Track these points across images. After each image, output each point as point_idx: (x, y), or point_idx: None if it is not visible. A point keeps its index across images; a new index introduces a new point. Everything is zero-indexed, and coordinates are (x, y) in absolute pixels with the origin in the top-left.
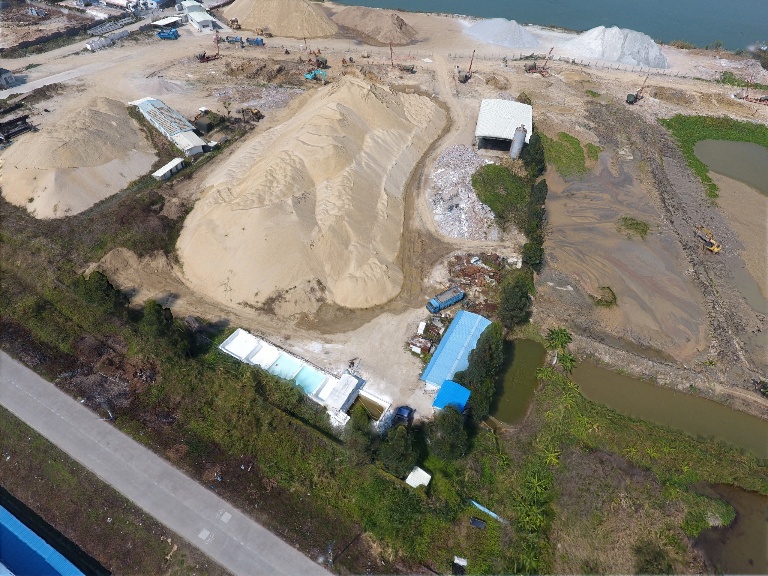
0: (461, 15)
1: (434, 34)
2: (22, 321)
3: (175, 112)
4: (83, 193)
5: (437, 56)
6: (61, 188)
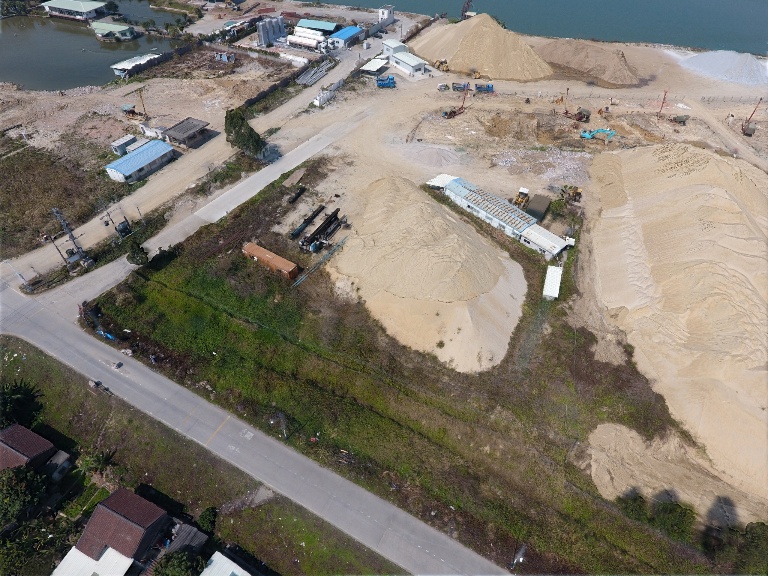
0: (663, 44)
1: (655, 70)
2: (583, 565)
3: None
4: (495, 331)
5: (687, 100)
6: (478, 328)
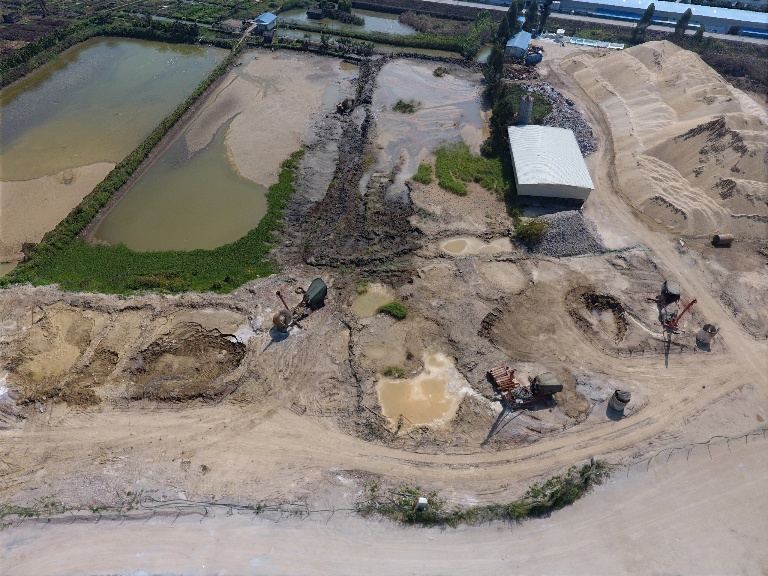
0: None
1: None
2: None
3: None
4: None
5: None
6: None
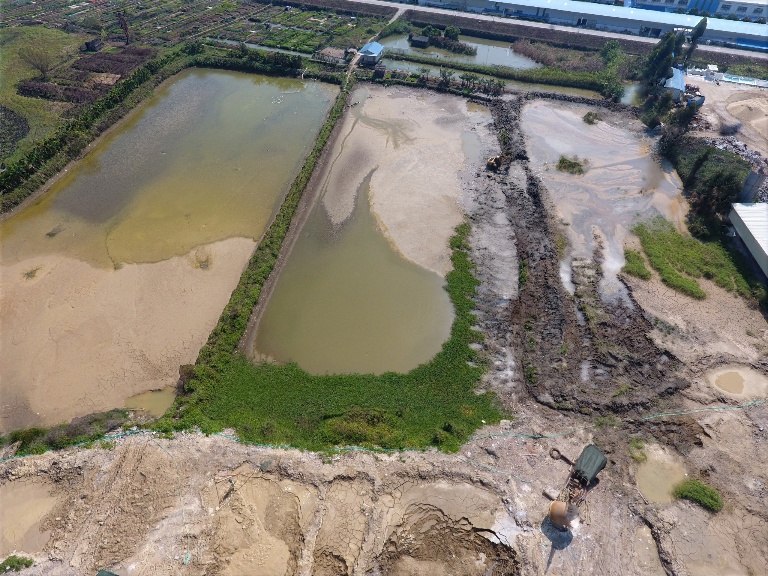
0: None
1: None
2: None
3: None
4: None
5: None
6: None
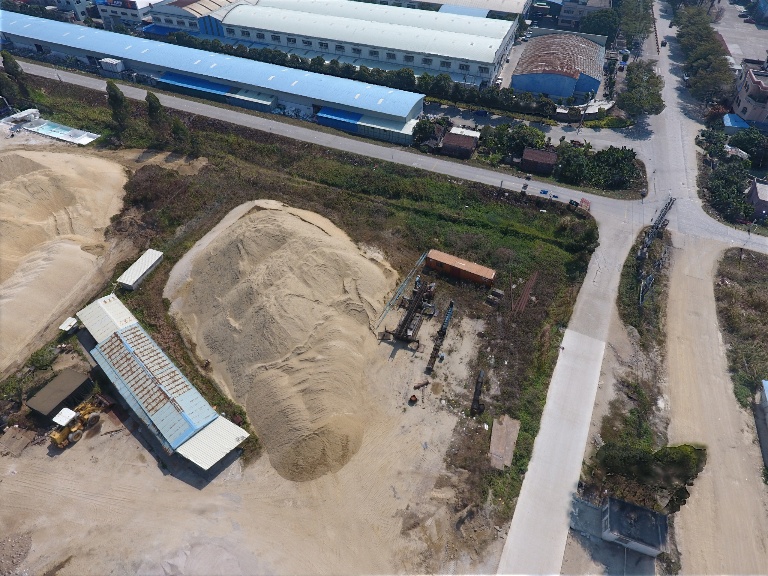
0: None
1: None
2: None
3: (132, 402)
4: None
5: None
6: None
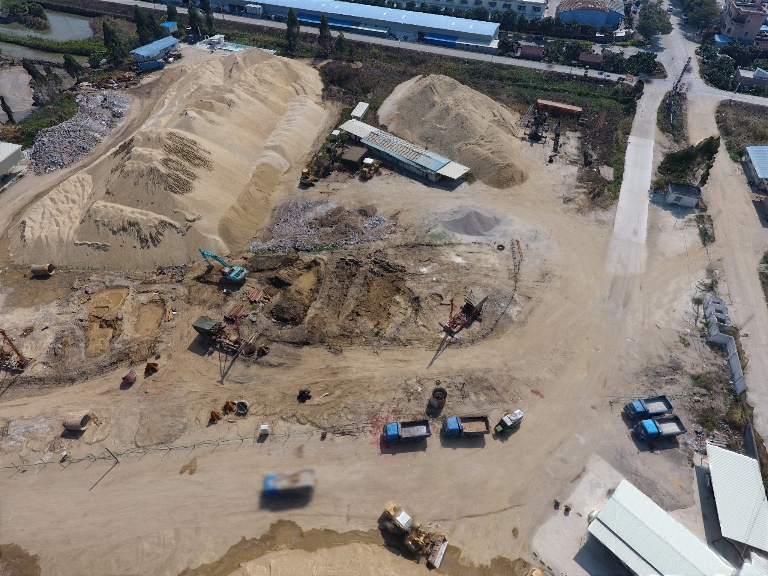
0: None
1: None
2: None
3: (400, 157)
4: None
5: None
6: None
